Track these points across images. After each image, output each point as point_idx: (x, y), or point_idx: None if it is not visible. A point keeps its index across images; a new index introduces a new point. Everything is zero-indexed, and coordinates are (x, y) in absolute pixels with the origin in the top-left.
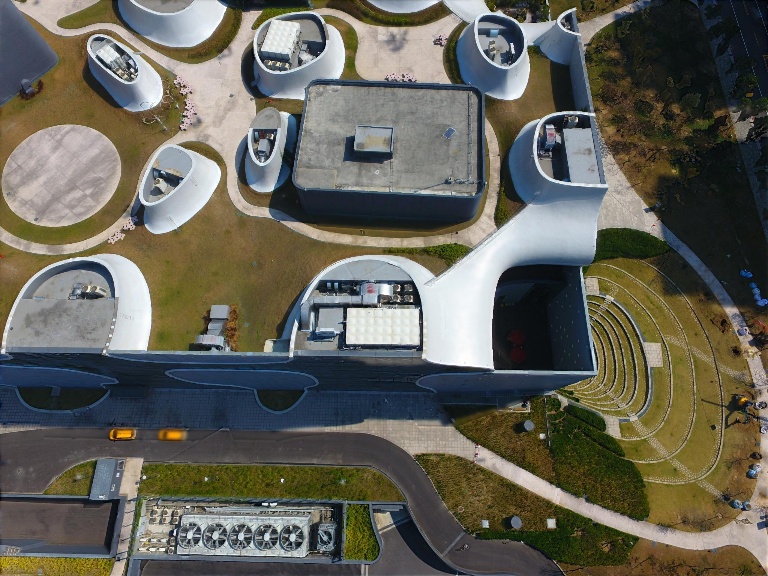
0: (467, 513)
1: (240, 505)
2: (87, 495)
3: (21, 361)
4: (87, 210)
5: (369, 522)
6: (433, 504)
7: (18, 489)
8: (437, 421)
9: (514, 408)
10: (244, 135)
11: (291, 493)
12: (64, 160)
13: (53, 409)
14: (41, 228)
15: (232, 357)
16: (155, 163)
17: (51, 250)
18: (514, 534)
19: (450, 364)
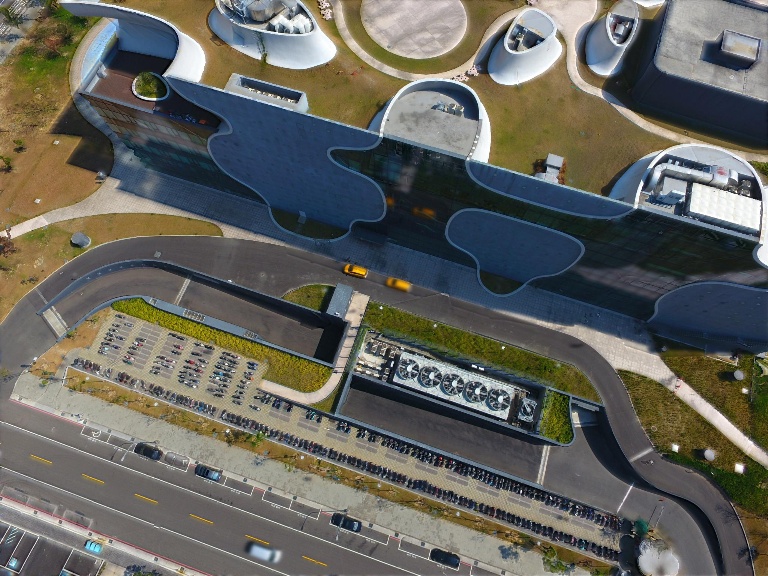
0: (659, 434)
1: (445, 363)
2: (320, 311)
3: (362, 158)
4: (434, 50)
5: (567, 411)
6: (627, 416)
7: (260, 289)
8: (644, 347)
9: (722, 358)
10: (585, 22)
11: (497, 365)
12: (416, 5)
13: (298, 233)
14: (393, 55)
15: (574, 196)
16: (519, 20)
17: (401, 75)
18: (702, 466)
19: (765, 263)
